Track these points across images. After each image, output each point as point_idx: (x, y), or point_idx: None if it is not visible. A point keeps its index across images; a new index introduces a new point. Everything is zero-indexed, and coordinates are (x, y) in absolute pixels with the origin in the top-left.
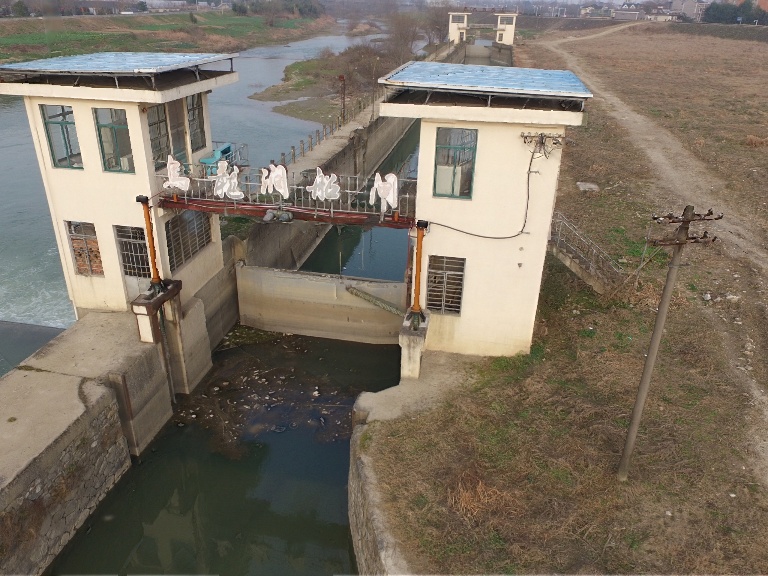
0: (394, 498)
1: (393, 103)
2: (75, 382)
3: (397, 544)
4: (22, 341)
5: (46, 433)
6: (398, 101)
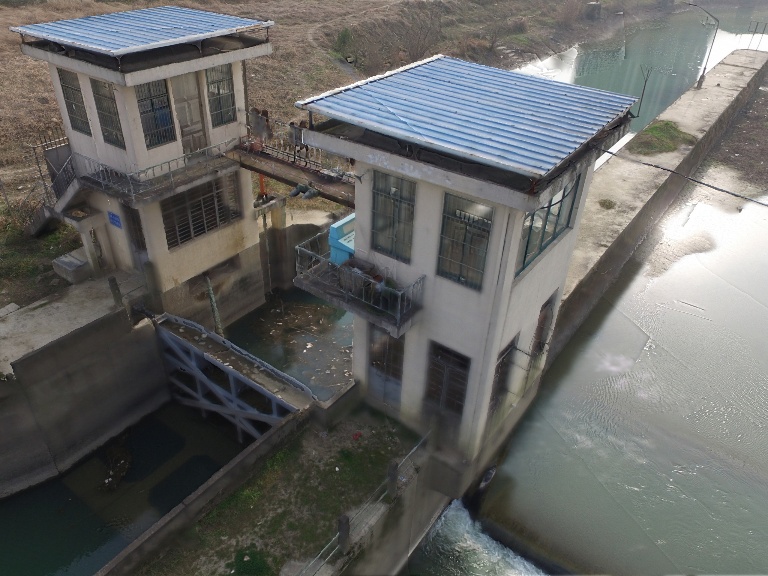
0: None
1: (262, 41)
2: None
3: None
4: None
5: None
6: (254, 41)
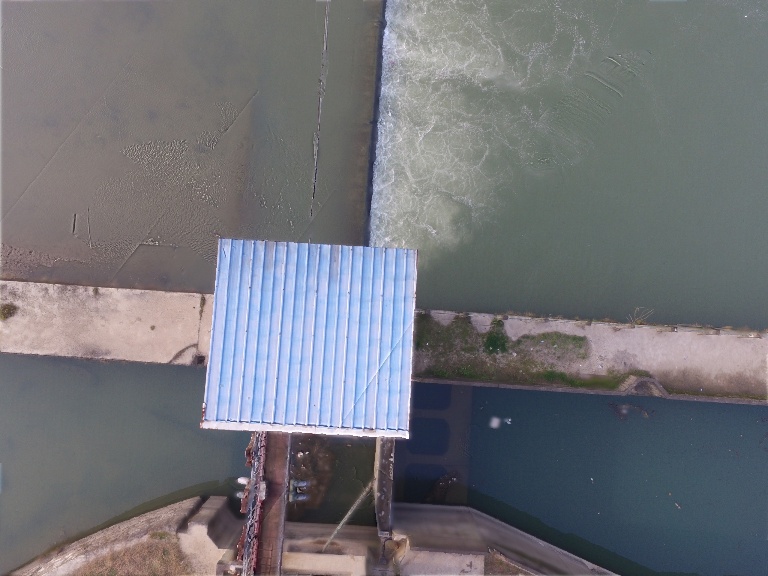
0: (114, 559)
1: None
2: (192, 342)
3: (88, 563)
4: (345, 204)
5: (144, 354)
6: None
